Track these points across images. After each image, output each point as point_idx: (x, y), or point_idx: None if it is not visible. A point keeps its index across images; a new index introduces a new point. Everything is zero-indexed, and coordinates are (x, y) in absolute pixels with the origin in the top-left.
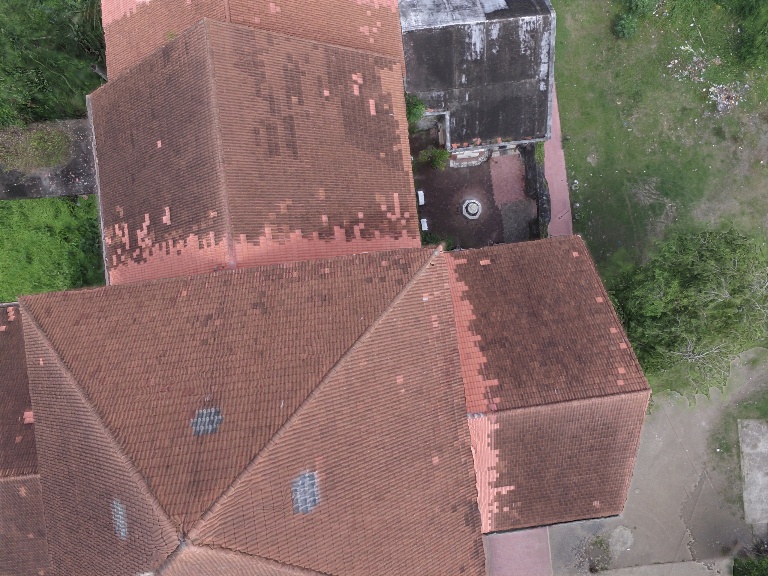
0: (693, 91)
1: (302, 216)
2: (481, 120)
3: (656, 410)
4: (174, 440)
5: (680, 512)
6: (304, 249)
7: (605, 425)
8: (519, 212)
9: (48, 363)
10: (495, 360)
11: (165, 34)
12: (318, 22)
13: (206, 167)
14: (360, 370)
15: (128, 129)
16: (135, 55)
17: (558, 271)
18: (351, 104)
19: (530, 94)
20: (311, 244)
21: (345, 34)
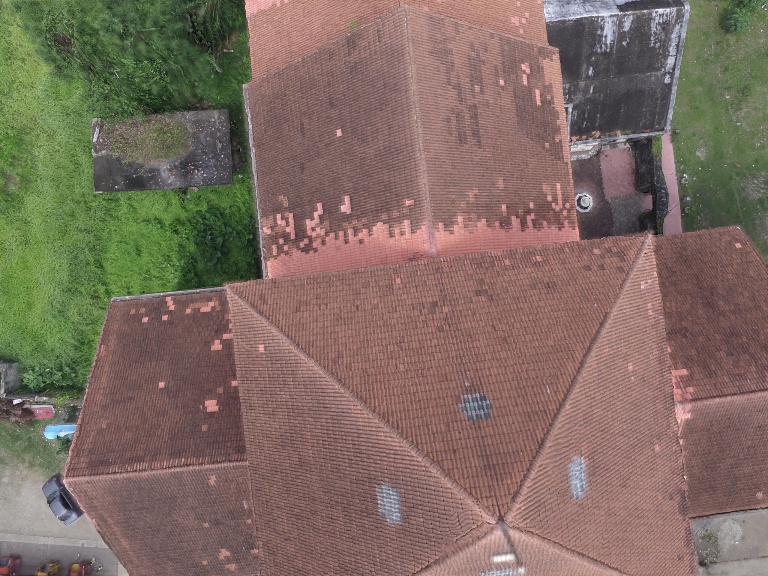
0: None
1: (486, 205)
2: (602, 113)
3: None
4: (450, 424)
5: None
6: (489, 238)
7: None
8: (629, 206)
9: (274, 349)
10: (679, 350)
11: (324, 23)
12: (477, 12)
13: (402, 155)
14: (605, 356)
15: (298, 118)
16: (286, 45)
17: (723, 262)
18: (521, 94)
19: (654, 87)
20: (494, 233)
21: (499, 24)
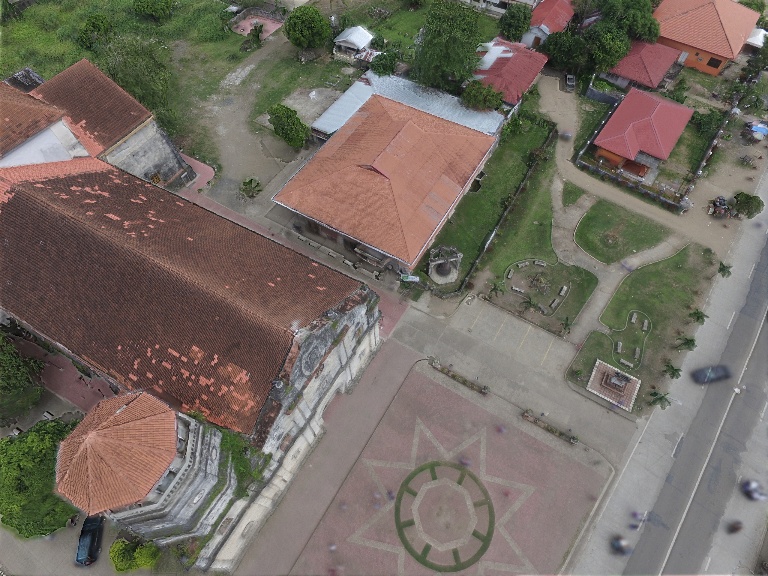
0: None
1: None
2: None
3: (219, 141)
4: None
5: (265, 156)
6: None
7: (86, 78)
8: None
9: None
10: None
11: None
12: None
13: None
14: None
15: None
16: None
17: None
18: None
19: None
20: None
21: None
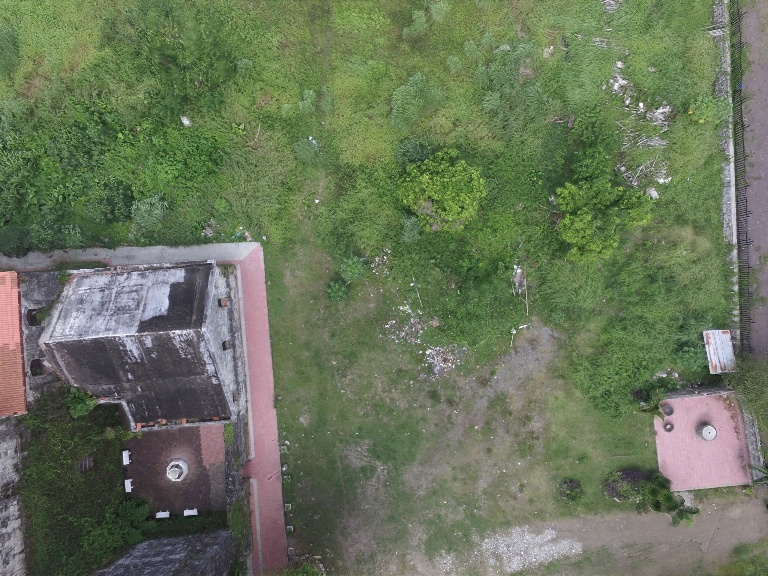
0: (409, 353)
1: None
2: (161, 405)
3: None
4: None
5: None
6: None
7: None
8: None
9: None
10: None
11: None
12: None
13: None
14: None
15: None
16: None
17: None
18: None
19: (204, 386)
20: None
21: None
